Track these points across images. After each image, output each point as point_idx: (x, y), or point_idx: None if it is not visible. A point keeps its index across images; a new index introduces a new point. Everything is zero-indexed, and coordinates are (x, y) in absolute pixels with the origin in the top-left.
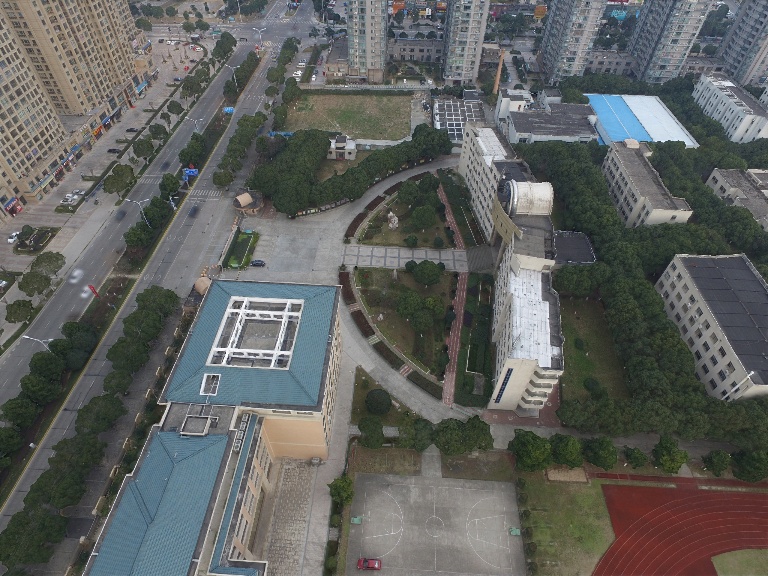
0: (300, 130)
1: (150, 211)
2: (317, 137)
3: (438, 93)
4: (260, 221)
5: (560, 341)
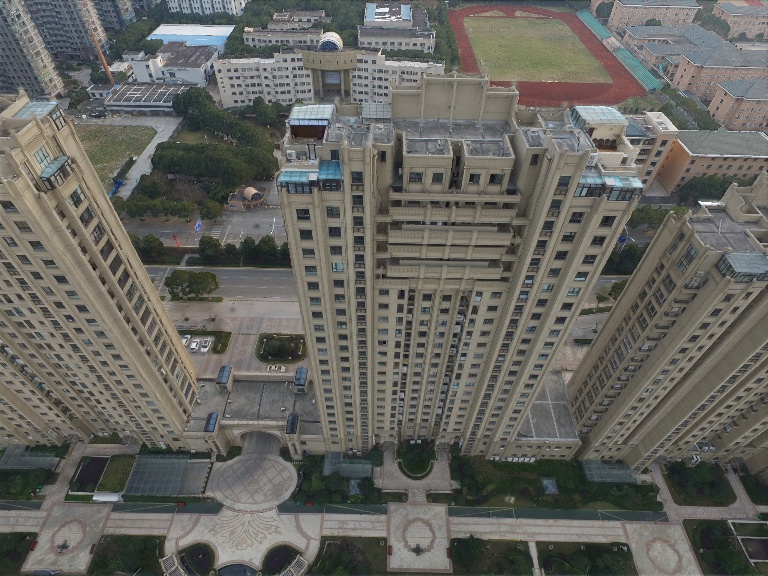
0: (157, 152)
1: (271, 237)
2: (176, 143)
3: (75, 106)
4: (273, 195)
5: (426, 62)
